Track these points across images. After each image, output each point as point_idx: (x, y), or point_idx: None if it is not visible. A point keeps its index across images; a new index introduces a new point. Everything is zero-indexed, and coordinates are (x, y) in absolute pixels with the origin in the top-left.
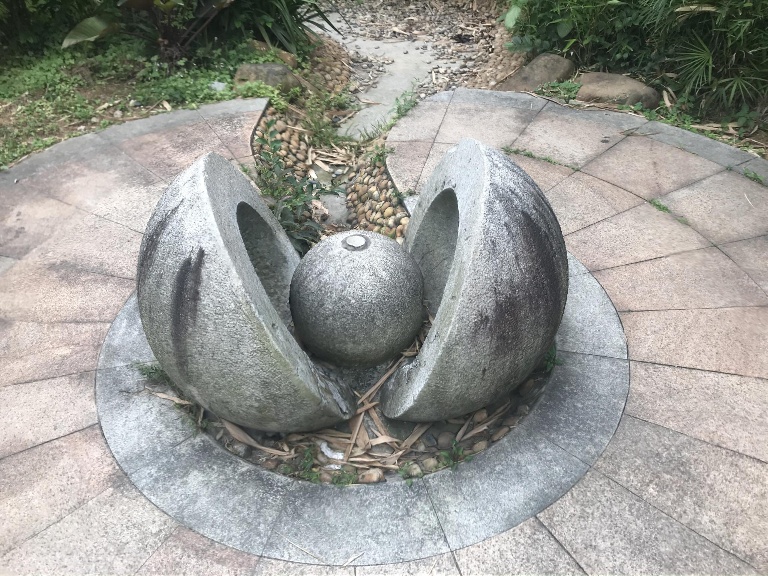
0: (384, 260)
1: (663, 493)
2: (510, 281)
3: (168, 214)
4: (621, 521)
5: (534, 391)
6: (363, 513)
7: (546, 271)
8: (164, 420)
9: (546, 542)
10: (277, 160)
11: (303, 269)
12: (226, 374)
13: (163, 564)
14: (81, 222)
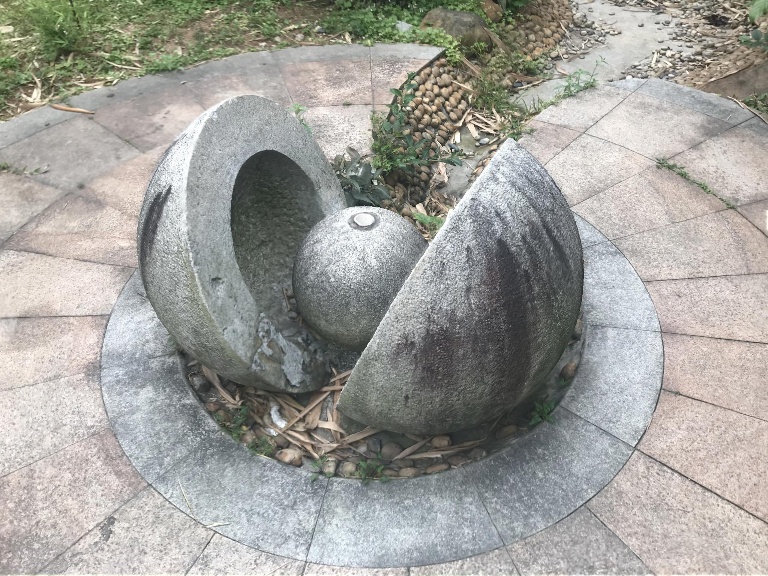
0: (381, 247)
1: None
2: (452, 313)
3: (173, 145)
4: None
5: (510, 439)
6: (255, 487)
7: (510, 315)
8: (157, 332)
9: None
10: (422, 115)
11: (309, 232)
12: (168, 310)
13: (77, 455)
14: None
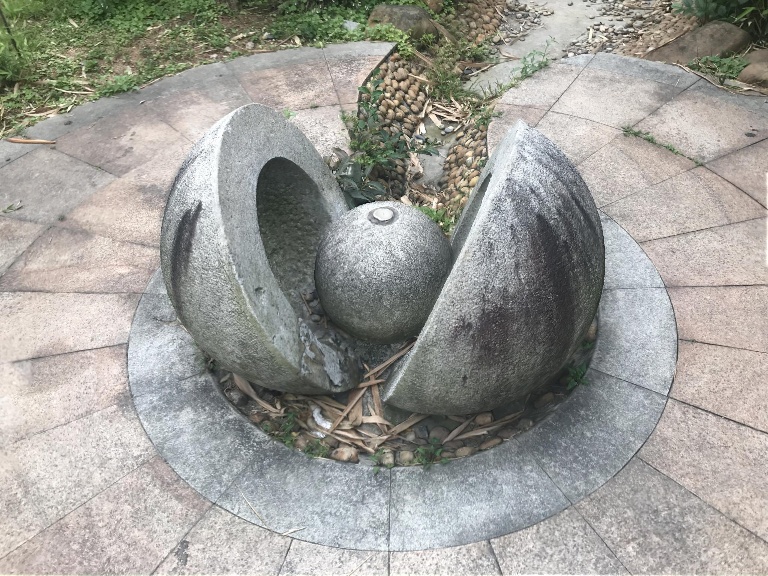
0: (406, 239)
1: (642, 556)
2: (504, 290)
3: (189, 162)
4: (580, 573)
5: (549, 406)
6: (320, 489)
7: (555, 285)
8: (181, 353)
9: (488, 571)
10: (386, 110)
11: (328, 234)
12: (210, 327)
13: (131, 486)
14: (180, 149)
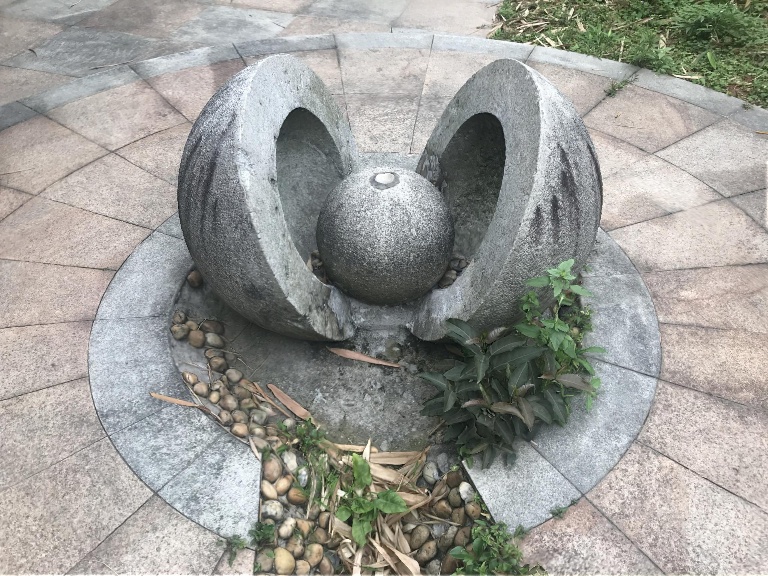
0: None
1: None
2: None
3: None
4: None
5: None
6: None
7: None
8: None
9: None
10: None
11: None
12: None
13: None
14: None
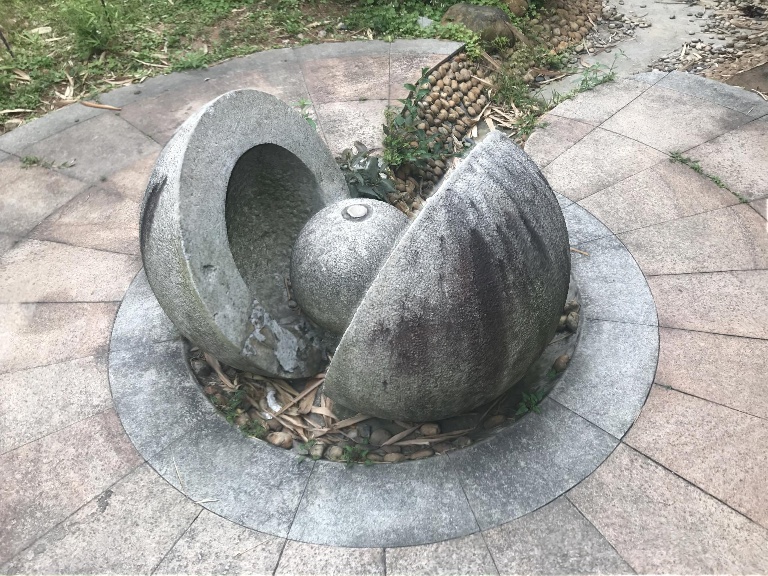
0: (372, 238)
1: None
2: (426, 301)
3: None
4: None
5: (497, 429)
6: (244, 467)
7: (484, 304)
8: (164, 318)
9: None
10: (439, 109)
11: None
12: (165, 296)
13: (81, 432)
14: None
